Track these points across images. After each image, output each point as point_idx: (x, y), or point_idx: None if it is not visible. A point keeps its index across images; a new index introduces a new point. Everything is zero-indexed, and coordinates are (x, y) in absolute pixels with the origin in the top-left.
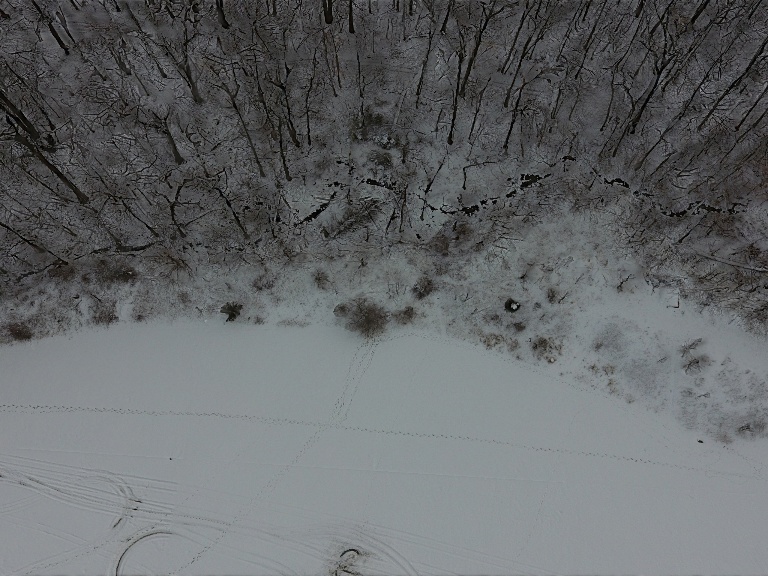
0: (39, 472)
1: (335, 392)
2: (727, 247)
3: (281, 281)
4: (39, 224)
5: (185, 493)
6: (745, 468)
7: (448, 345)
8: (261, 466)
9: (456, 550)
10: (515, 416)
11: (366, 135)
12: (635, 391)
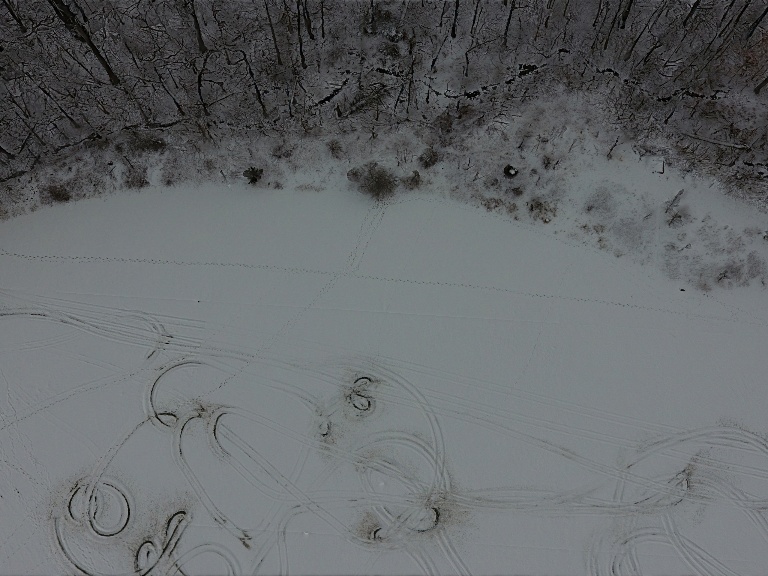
0: (79, 312)
1: (348, 247)
2: (709, 127)
3: (298, 151)
4: (75, 103)
5: (212, 330)
6: (723, 312)
7: (452, 208)
8: (281, 308)
9: (459, 378)
10: (513, 267)
11: (376, 29)
12: (623, 247)
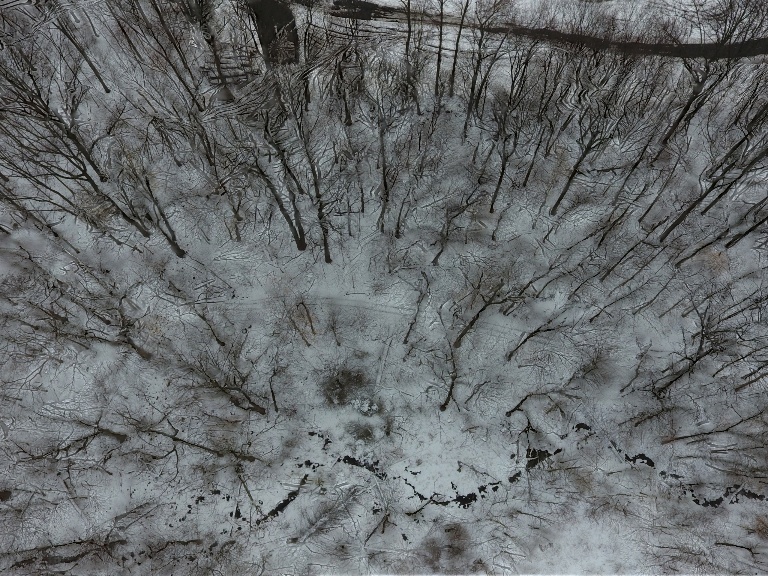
0: None
1: None
2: None
3: None
4: None
5: None
6: None
7: None
8: None
9: None
10: None
11: (344, 398)
12: None
